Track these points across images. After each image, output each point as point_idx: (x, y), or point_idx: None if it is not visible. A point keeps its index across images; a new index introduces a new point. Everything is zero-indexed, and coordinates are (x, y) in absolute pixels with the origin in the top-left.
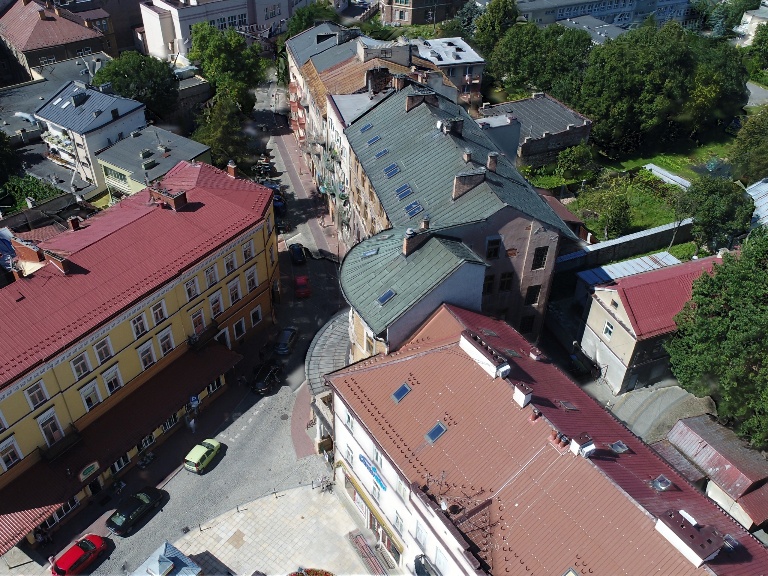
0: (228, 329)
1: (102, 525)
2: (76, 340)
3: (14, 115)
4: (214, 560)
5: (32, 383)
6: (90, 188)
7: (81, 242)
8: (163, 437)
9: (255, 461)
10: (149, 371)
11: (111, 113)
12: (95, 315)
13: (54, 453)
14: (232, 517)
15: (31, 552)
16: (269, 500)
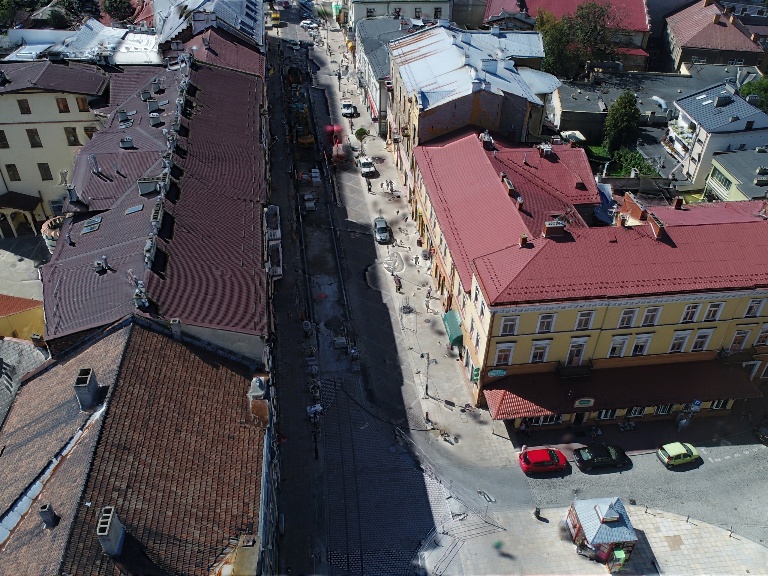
0: (760, 363)
1: (570, 450)
2: (639, 295)
3: (651, 97)
4: (646, 542)
5: (588, 309)
6: (686, 182)
7: (680, 220)
8: (651, 417)
9: (724, 492)
10: (672, 356)
11: (746, 123)
12: (663, 283)
13: (567, 372)
14: (679, 521)
15: (512, 432)
16: (722, 533)
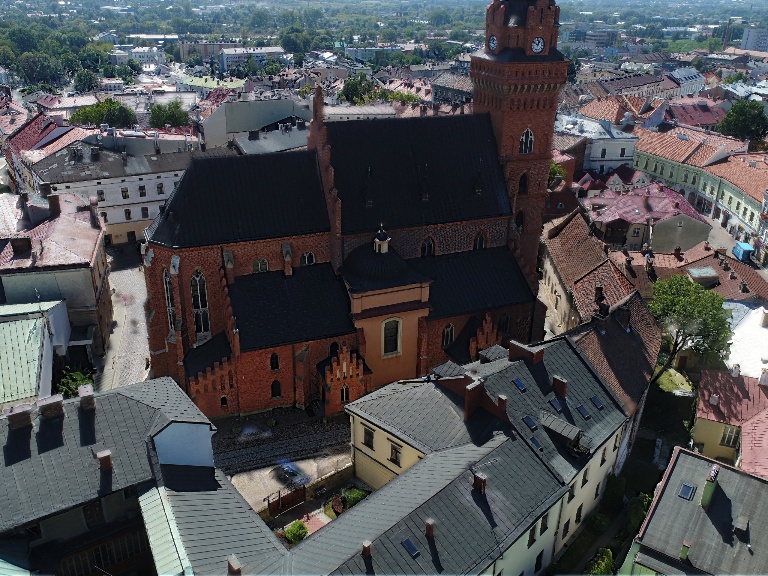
0: None
1: None
2: None
3: None
4: None
5: None
6: None
7: None
8: None
9: None
10: None
11: None
12: None
13: None
14: None
15: None
16: None
